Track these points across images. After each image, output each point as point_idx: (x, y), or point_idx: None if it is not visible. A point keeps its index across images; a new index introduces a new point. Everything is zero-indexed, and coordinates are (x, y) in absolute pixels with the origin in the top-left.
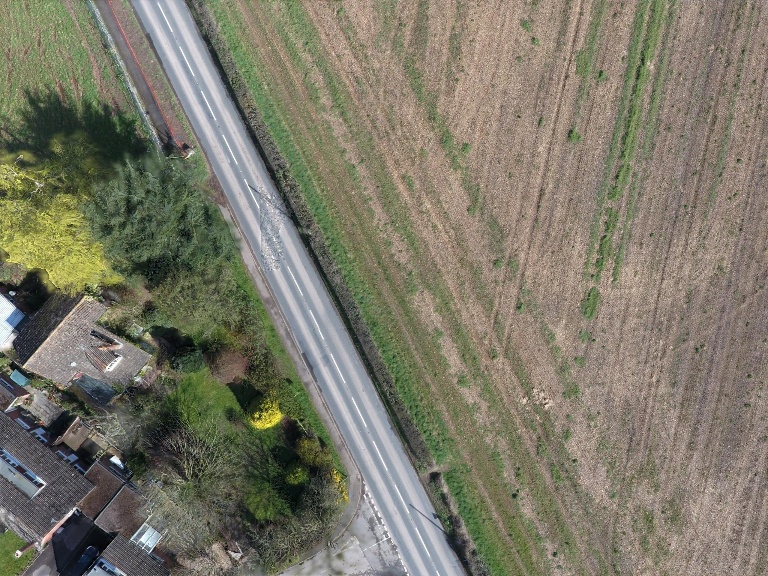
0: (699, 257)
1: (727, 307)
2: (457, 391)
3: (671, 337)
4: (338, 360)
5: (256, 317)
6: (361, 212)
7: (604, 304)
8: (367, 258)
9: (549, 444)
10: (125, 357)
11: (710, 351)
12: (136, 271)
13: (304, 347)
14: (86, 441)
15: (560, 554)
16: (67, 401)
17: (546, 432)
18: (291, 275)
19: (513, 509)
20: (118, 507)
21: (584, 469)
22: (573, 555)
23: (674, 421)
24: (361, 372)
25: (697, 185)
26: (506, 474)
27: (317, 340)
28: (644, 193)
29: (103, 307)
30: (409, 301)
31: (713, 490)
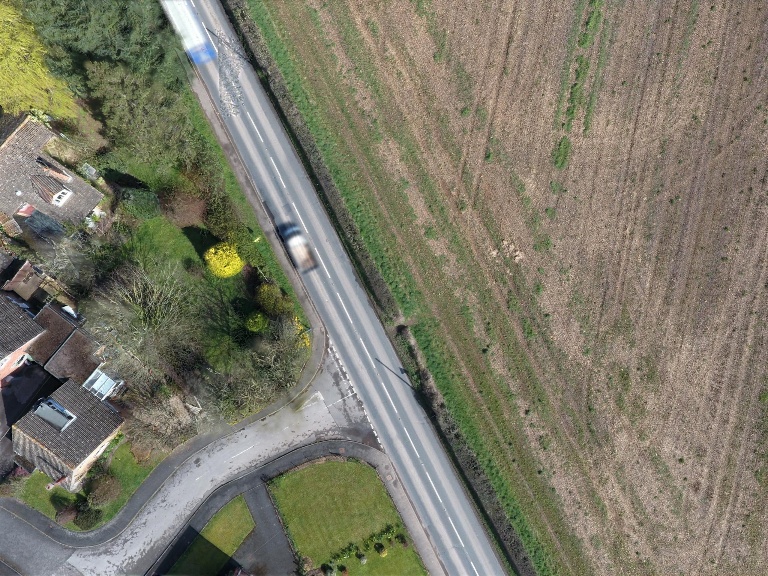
0: (673, 106)
1: (702, 158)
2: (424, 243)
3: (645, 188)
4: (300, 209)
5: (213, 158)
6: (323, 58)
7: (575, 154)
8: (330, 105)
9: (520, 298)
10: (75, 193)
11: (685, 203)
12: (77, 69)
13: (265, 195)
14: (38, 291)
15: (532, 412)
16: (16, 245)
17: (517, 286)
18: (251, 121)
19: (483, 365)
20: (69, 352)
21: (557, 324)
22: (546, 413)
23: (649, 275)
24: (324, 222)
25: (670, 33)
26: (476, 329)
27: (278, 188)
28: (615, 40)
29: (49, 131)
30: (374, 150)
31: (690, 346)
